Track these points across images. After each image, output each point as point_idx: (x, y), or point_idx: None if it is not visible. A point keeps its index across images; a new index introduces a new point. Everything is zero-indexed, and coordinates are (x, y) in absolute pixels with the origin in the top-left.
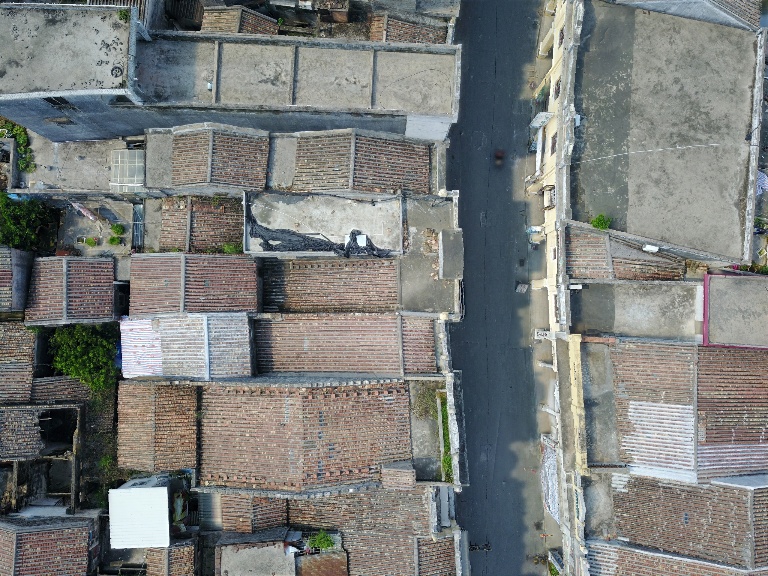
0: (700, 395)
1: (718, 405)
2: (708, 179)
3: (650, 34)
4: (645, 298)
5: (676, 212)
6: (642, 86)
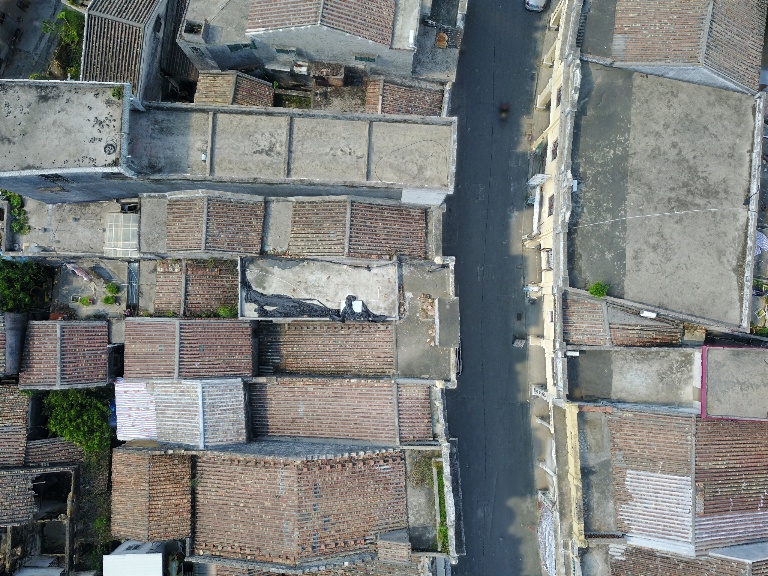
0: (698, 466)
1: (716, 475)
2: (706, 244)
3: (648, 98)
4: (643, 364)
5: (674, 278)
6: (640, 150)
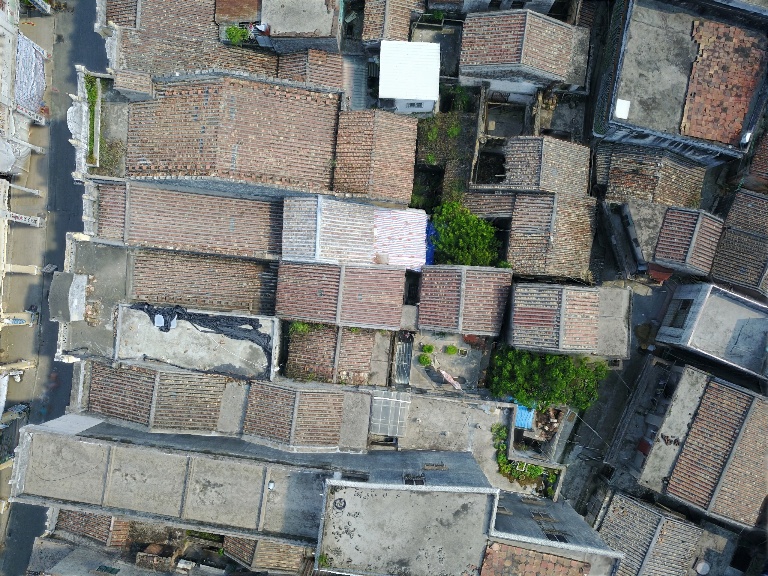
0: None
1: None
2: None
3: None
4: None
5: None
6: None
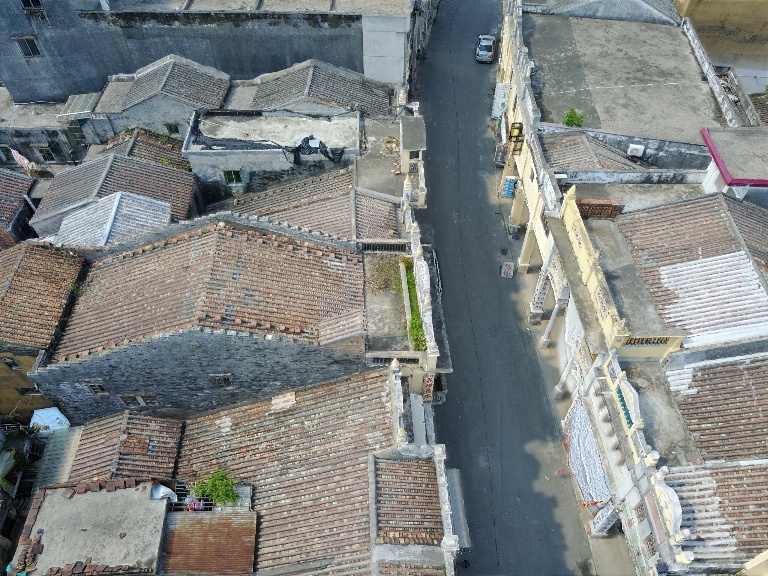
0: (748, 243)
1: None
2: (677, 104)
3: (586, 28)
4: (645, 195)
5: (653, 124)
6: (588, 53)
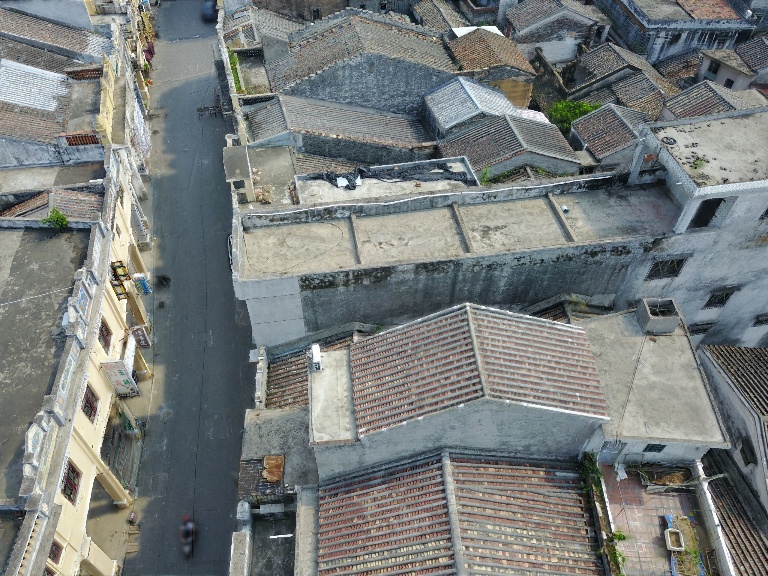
0: None
1: None
2: None
3: None
4: None
5: None
6: None
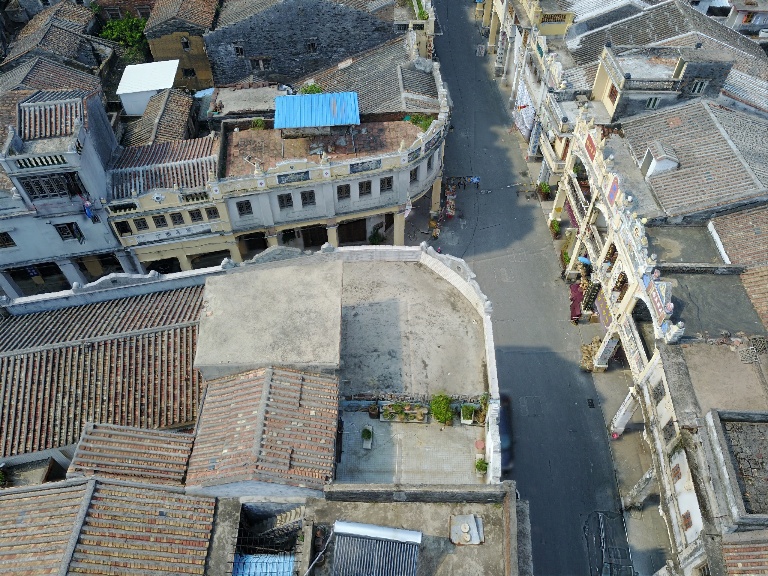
0: None
1: None
2: None
3: None
4: None
5: None
6: None
